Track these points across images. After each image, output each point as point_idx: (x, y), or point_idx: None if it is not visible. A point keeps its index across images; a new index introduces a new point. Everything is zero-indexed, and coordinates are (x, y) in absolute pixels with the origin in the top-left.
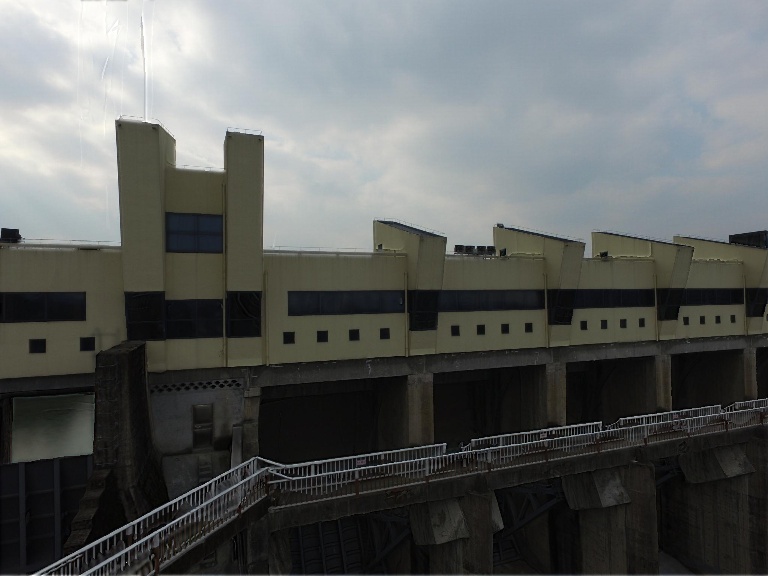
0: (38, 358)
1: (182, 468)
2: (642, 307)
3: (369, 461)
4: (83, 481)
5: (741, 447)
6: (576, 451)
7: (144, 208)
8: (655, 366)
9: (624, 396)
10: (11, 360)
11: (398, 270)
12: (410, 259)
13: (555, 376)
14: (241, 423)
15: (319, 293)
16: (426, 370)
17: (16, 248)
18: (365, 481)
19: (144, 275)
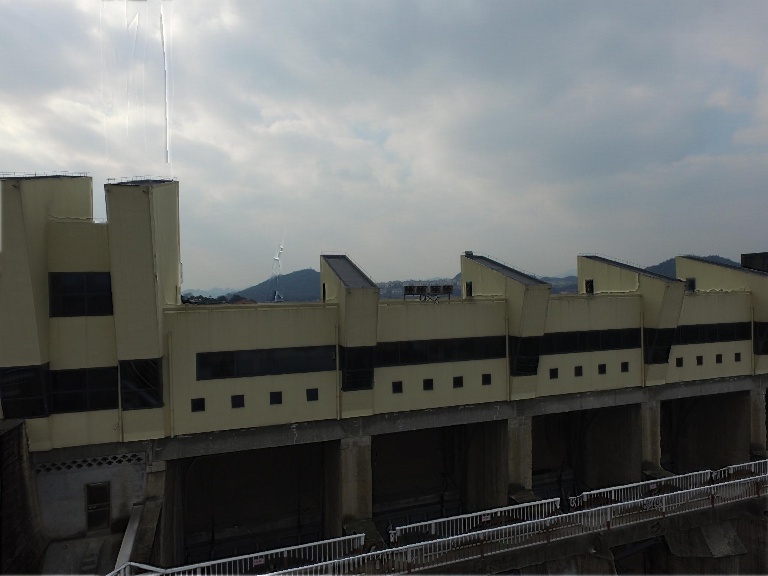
0: None
1: (66, 559)
2: (625, 349)
3: (269, 559)
4: None
5: (731, 523)
6: (520, 542)
7: (10, 275)
8: (641, 415)
9: (608, 443)
10: None
11: (328, 322)
12: (341, 311)
13: (518, 432)
14: (143, 501)
15: (234, 353)
16: (363, 432)
17: None
18: None
19: (17, 348)
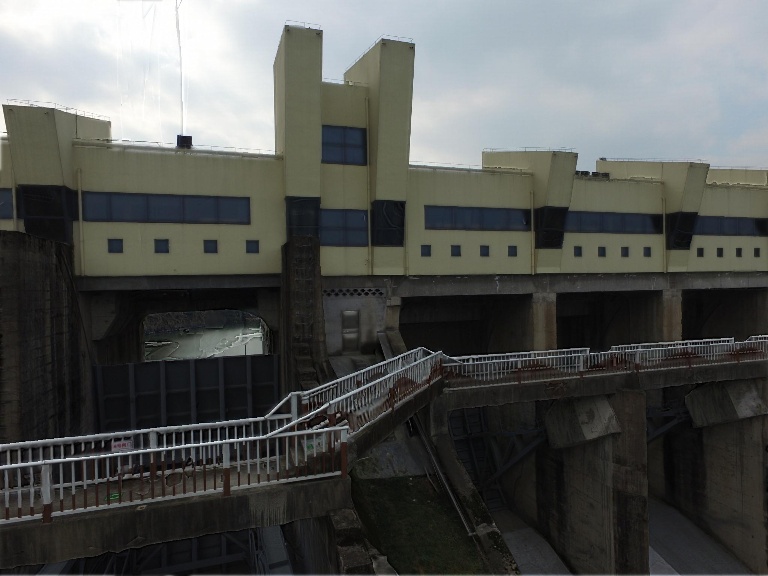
0: (211, 258)
1: (339, 365)
2: (758, 236)
3: None
4: (241, 381)
5: None
6: (717, 359)
7: (306, 114)
8: None
9: (730, 332)
10: (189, 258)
11: (524, 189)
12: (537, 177)
13: (671, 302)
14: (384, 330)
15: (452, 208)
16: (550, 289)
17: (189, 154)
18: (526, 371)
19: (304, 181)
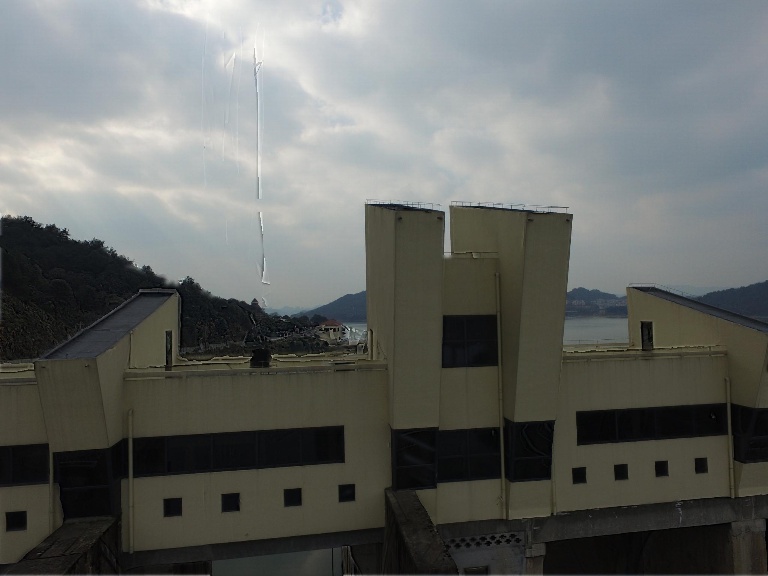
0: (293, 512)
1: None
2: None
3: None
4: None
5: None
6: None
7: (421, 322)
8: None
9: None
10: (265, 516)
11: (716, 375)
12: (737, 361)
13: None
14: None
15: (614, 412)
16: (755, 514)
17: (268, 373)
18: None
19: (417, 407)
